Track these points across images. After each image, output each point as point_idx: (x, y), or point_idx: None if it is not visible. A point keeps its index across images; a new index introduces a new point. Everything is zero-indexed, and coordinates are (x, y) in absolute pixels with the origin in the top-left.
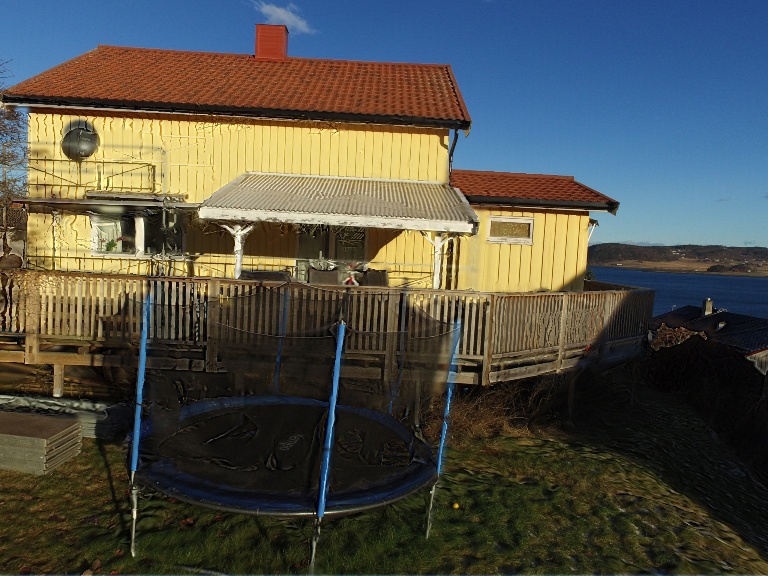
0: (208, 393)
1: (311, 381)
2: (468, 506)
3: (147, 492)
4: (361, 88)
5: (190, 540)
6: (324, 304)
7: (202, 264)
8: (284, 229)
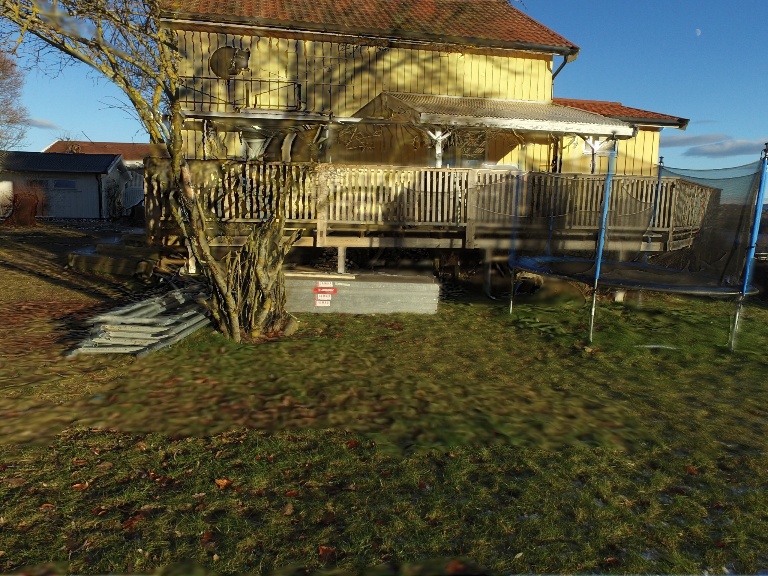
0: (462, 267)
1: None
2: None
3: (604, 294)
4: None
5: None
6: (557, 189)
7: None
8: (416, 144)
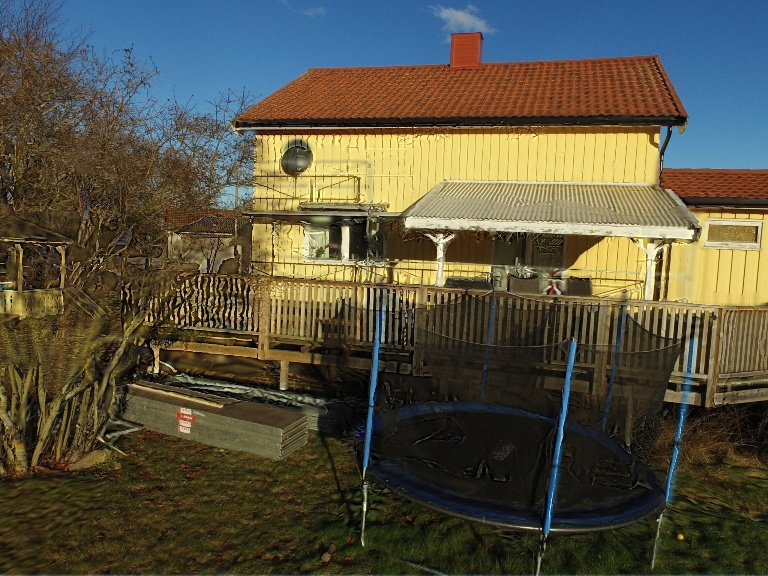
0: (414, 395)
1: (514, 390)
2: (695, 539)
3: (376, 488)
4: (560, 89)
5: (411, 537)
6: (530, 314)
7: (401, 270)
8: (480, 235)
